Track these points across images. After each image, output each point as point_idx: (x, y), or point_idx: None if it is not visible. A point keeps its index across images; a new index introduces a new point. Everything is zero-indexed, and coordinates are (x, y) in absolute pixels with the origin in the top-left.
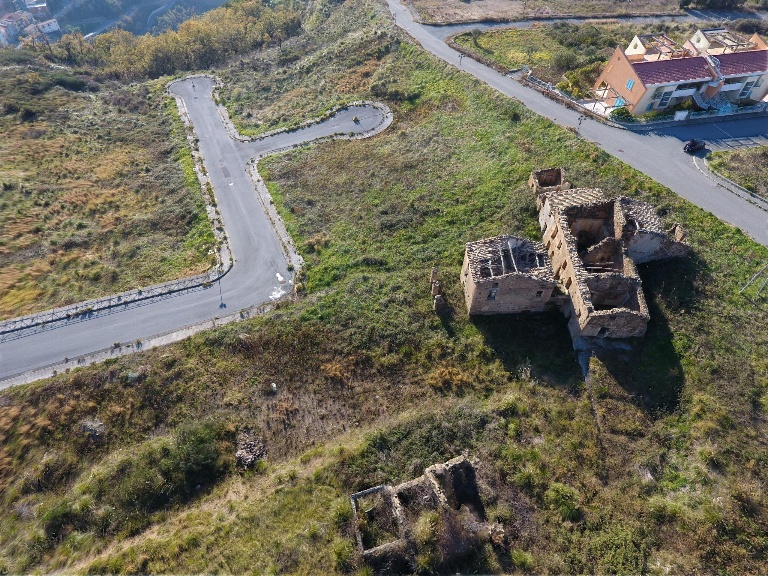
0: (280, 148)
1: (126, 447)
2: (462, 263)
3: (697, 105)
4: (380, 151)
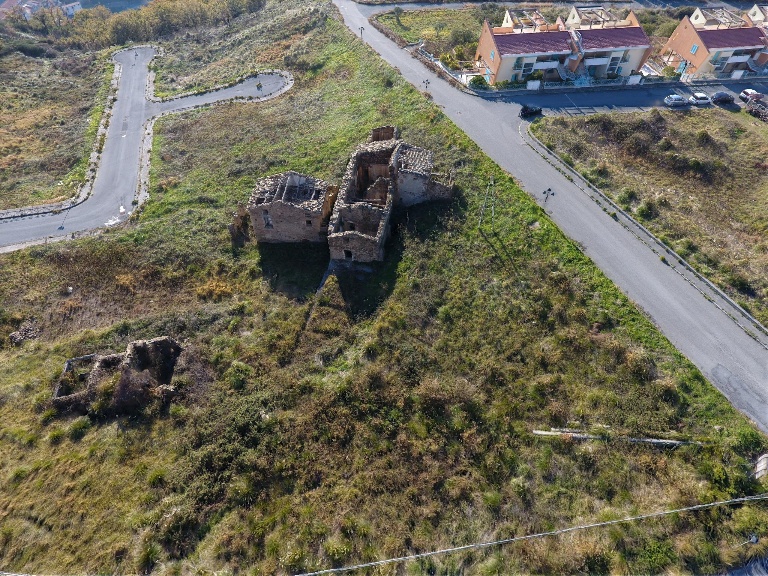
0: (183, 108)
1: None
2: None
3: (560, 77)
4: (264, 112)
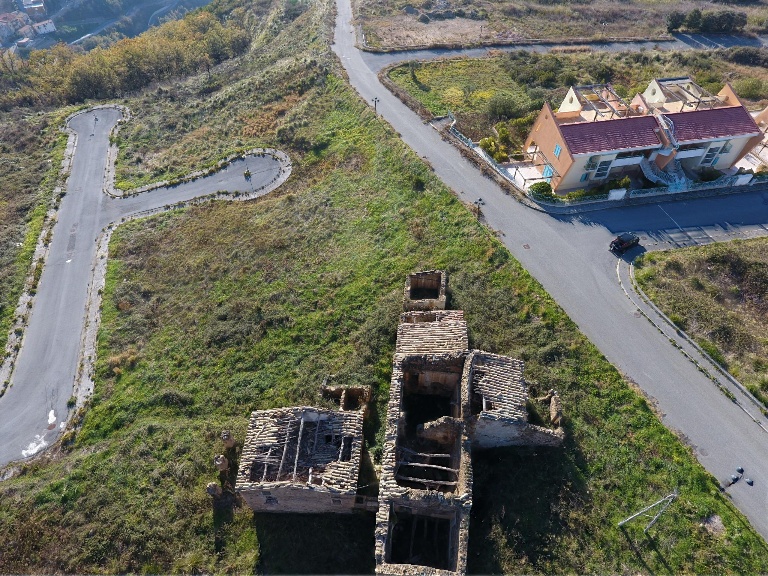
0: (149, 209)
1: None
2: None
3: (644, 176)
4: (256, 221)
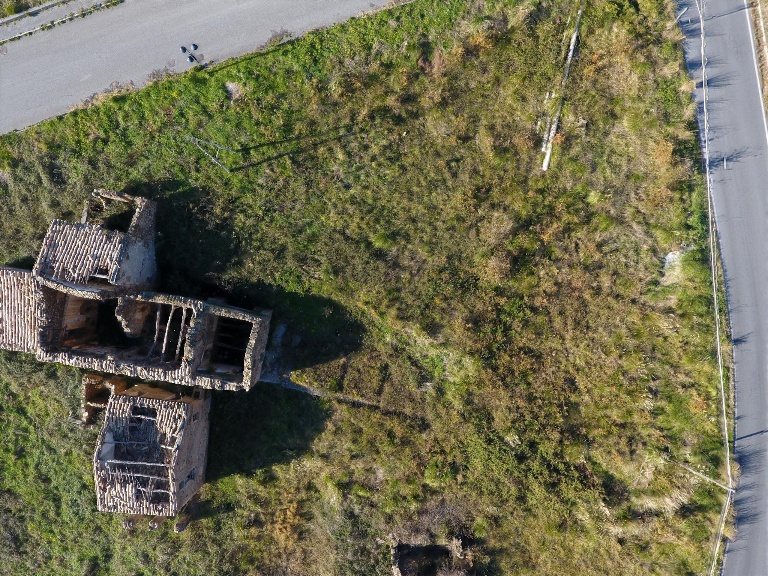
0: None
1: None
2: None
3: None
4: None
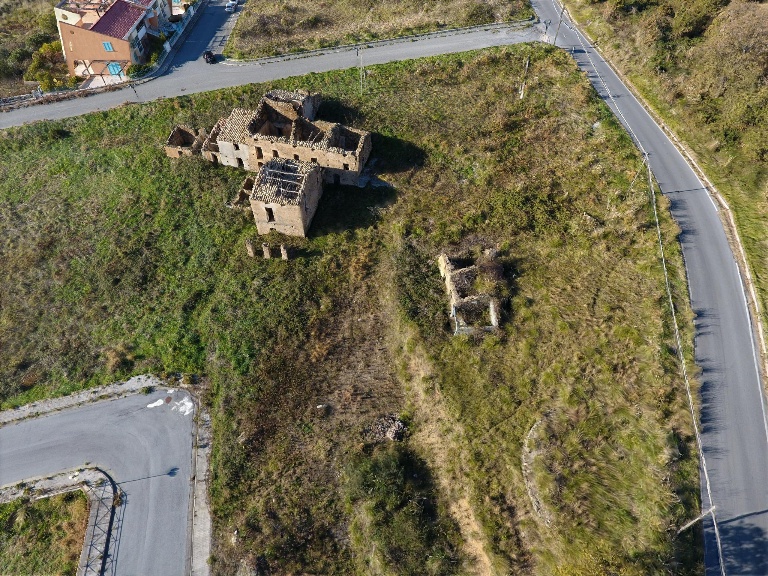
0: None
1: (353, 571)
2: (240, 230)
3: None
4: None
